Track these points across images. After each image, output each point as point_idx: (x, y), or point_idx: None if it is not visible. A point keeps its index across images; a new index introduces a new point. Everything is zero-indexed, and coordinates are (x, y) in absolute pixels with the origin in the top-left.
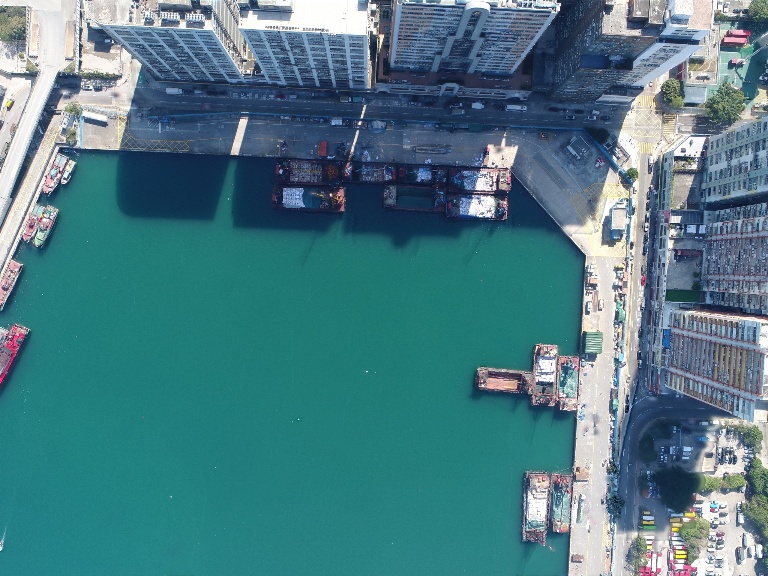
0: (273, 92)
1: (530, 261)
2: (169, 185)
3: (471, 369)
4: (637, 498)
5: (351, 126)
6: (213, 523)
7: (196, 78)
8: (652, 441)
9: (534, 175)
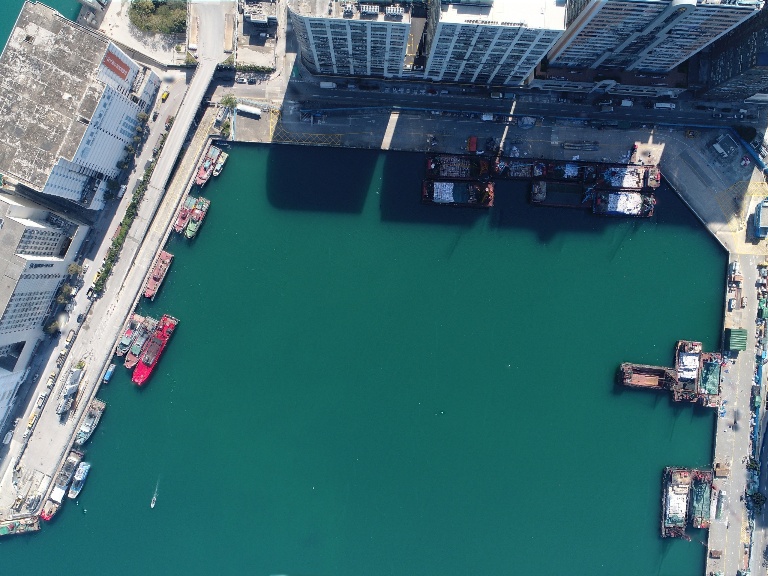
0: (424, 87)
1: (674, 258)
2: (318, 178)
3: (613, 365)
4: None
5: (501, 122)
6: (355, 515)
7: (353, 72)
8: None
9: (680, 172)
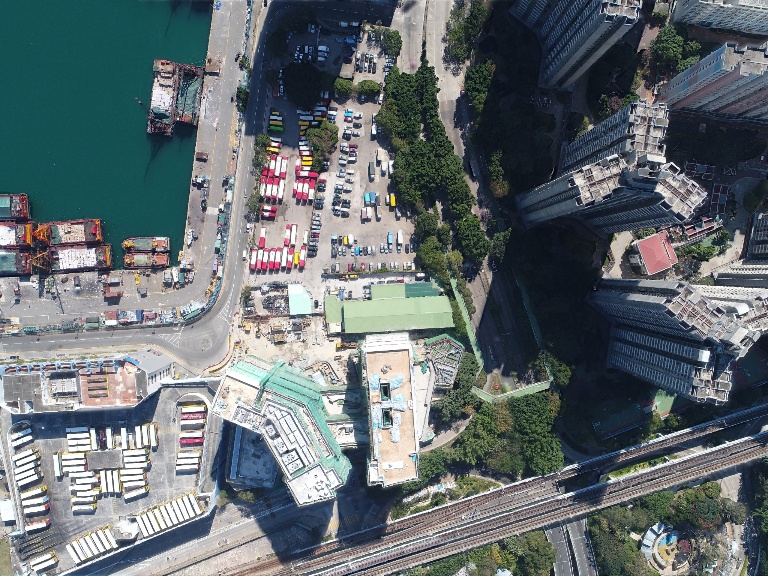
0: None
1: None
2: None
3: None
4: (269, 99)
5: None
6: None
7: None
8: (283, 32)
9: None
